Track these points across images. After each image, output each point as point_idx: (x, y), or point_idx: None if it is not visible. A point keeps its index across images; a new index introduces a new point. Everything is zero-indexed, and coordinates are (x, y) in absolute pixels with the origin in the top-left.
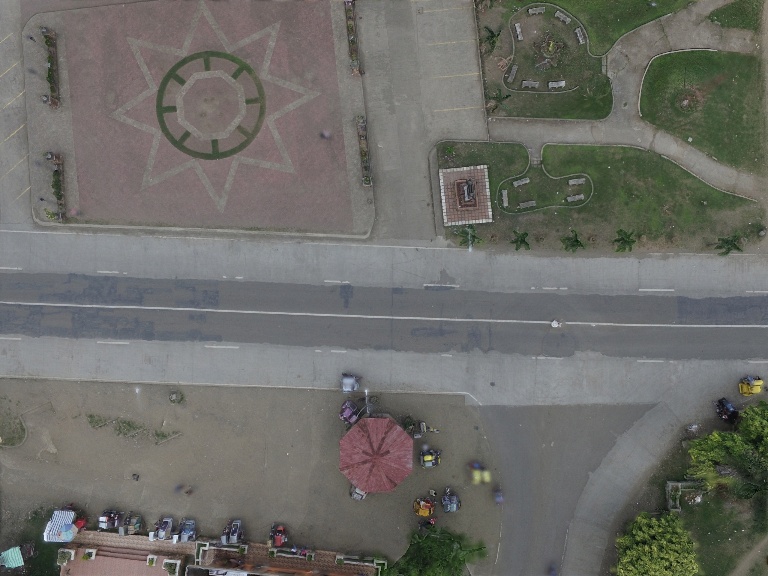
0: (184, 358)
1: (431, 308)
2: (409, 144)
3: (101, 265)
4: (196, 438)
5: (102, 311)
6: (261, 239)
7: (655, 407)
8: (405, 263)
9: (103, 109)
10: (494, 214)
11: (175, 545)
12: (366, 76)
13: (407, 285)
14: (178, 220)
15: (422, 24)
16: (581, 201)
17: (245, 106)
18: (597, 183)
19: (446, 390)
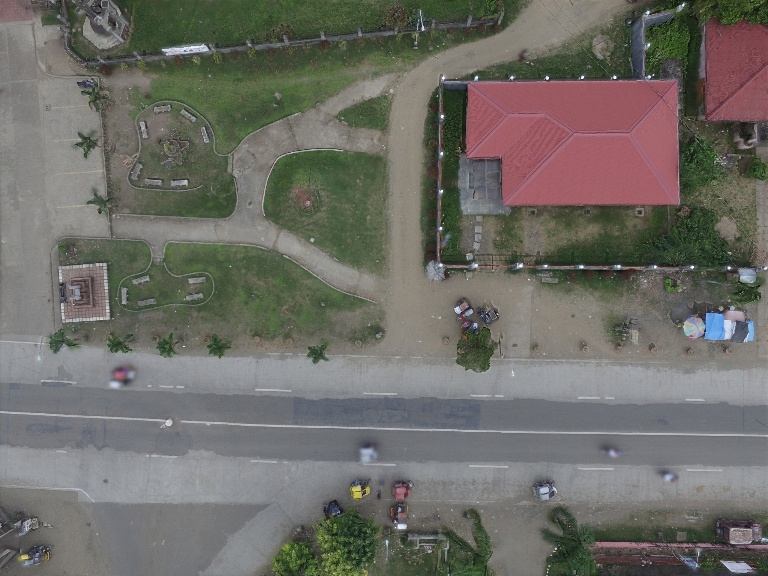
0: None
1: (47, 404)
2: (32, 240)
3: None
4: None
5: None
6: None
7: (268, 508)
8: (23, 358)
9: None
10: (114, 311)
11: None
12: None
13: (25, 380)
14: None
15: (49, 120)
16: (202, 299)
17: None
18: (218, 282)
19: (60, 486)
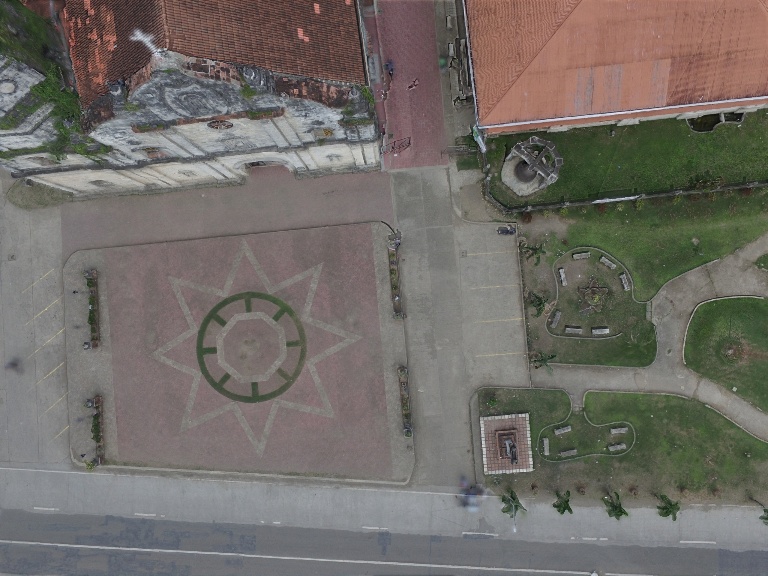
0: None
1: (469, 557)
2: (450, 389)
3: (139, 507)
4: None
5: (139, 554)
6: (299, 483)
7: None
8: (444, 510)
9: (143, 349)
10: (535, 462)
11: None
12: (408, 319)
13: (446, 533)
14: (217, 463)
15: (465, 267)
16: (623, 449)
17: (286, 349)
18: (639, 432)
19: None
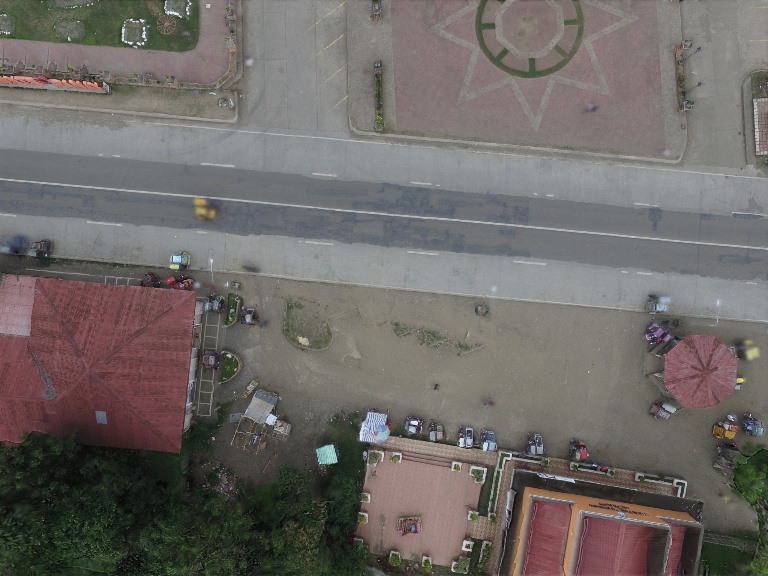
0: (492, 272)
1: (738, 236)
2: (723, 72)
3: (415, 176)
4: (498, 351)
5: (414, 221)
6: (573, 159)
7: None
8: (714, 190)
9: (423, 23)
10: None
11: (474, 455)
12: (683, 3)
13: (715, 212)
14: (493, 136)
15: None
16: None
17: (563, 27)
18: None
19: (749, 317)
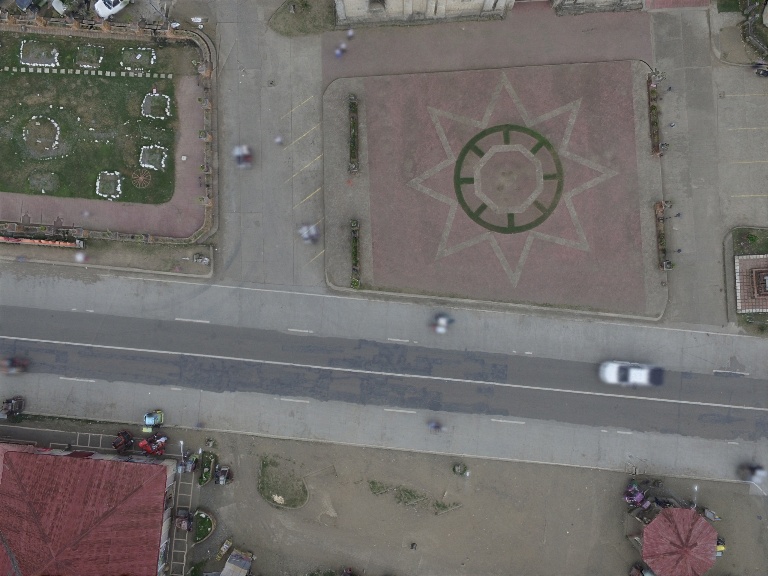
0: (470, 430)
1: (720, 394)
2: (704, 228)
3: (392, 333)
4: (476, 510)
5: (391, 379)
6: (552, 315)
7: None
8: (695, 348)
9: (401, 177)
10: None
11: None
12: (664, 157)
13: (696, 370)
14: (471, 292)
15: (723, 108)
16: None
17: (543, 181)
18: None
19: (731, 478)
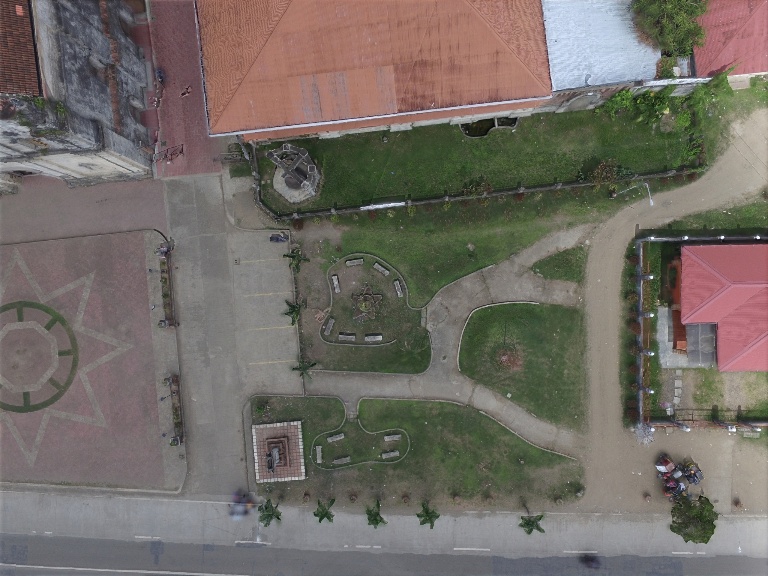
0: None
1: (242, 566)
2: (223, 397)
3: None
4: None
5: None
6: (72, 493)
7: None
8: (217, 519)
9: None
10: (308, 469)
11: None
12: (181, 327)
13: (218, 542)
14: None
15: (238, 275)
16: (397, 457)
17: (57, 358)
18: (414, 439)
19: None
